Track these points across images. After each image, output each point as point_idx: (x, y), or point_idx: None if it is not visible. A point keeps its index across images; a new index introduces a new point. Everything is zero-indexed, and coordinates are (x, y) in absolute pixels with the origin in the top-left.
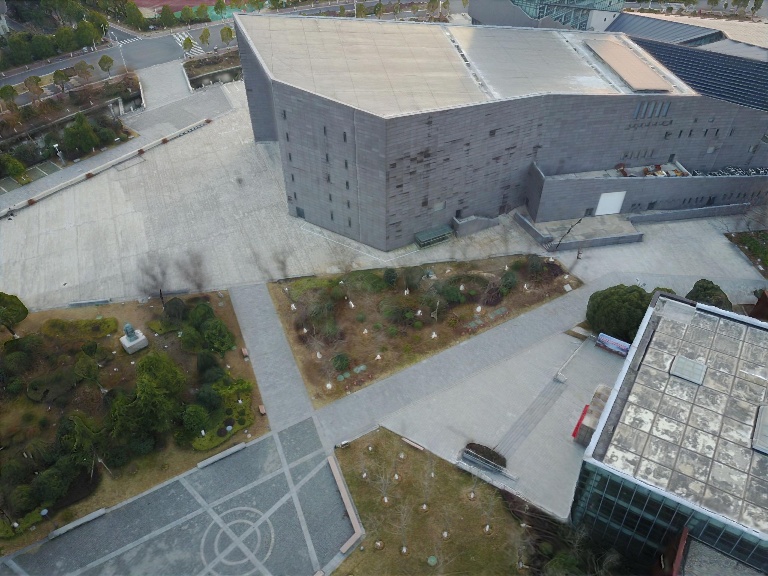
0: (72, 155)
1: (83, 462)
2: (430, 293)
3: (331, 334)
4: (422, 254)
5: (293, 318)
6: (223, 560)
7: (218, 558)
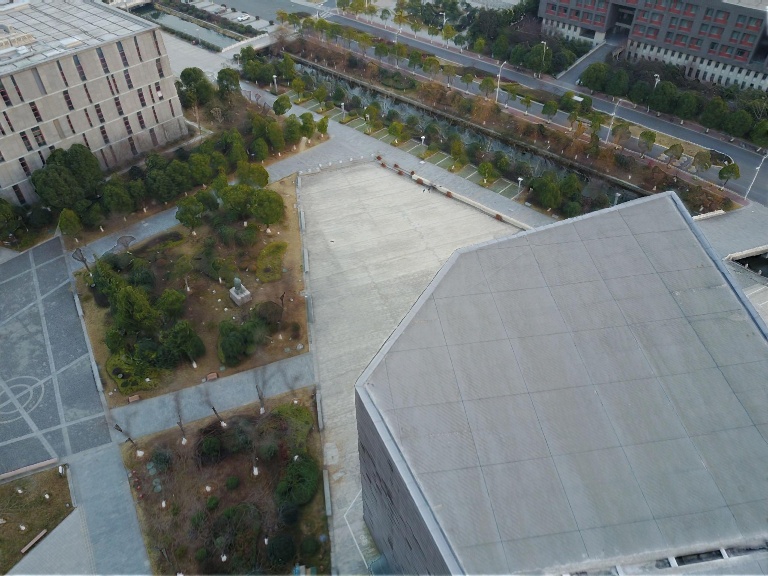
0: (532, 198)
1: (104, 287)
2: (251, 570)
3: (203, 447)
4: (358, 572)
5: (249, 413)
6: (4, 391)
7: (7, 388)
